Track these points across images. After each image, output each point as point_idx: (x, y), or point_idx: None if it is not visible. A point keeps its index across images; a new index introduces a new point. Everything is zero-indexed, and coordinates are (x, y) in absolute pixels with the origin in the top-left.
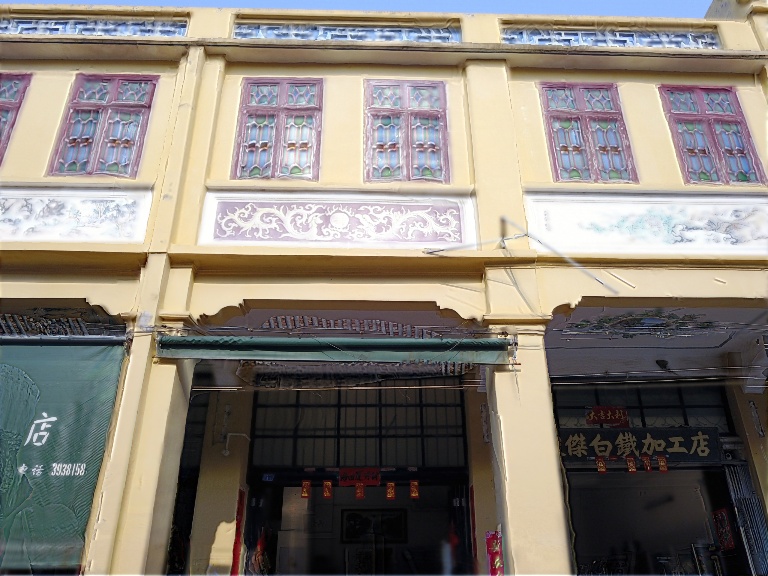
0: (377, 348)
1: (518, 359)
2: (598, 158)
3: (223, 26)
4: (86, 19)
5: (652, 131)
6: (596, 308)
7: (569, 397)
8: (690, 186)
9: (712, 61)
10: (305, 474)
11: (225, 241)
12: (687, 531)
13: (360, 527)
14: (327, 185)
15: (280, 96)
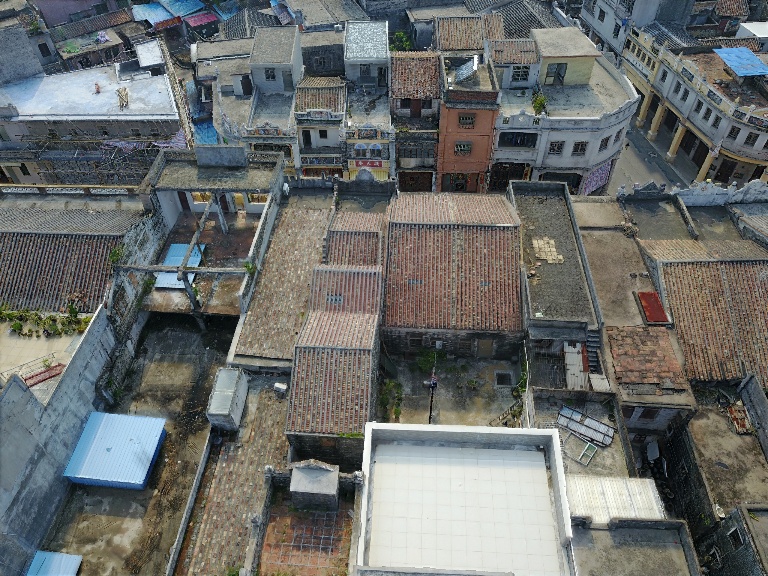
0: None
1: None
2: None
3: None
4: None
5: None
6: None
7: None
8: None
9: None
10: None
11: None
12: None
13: None
14: None
15: None
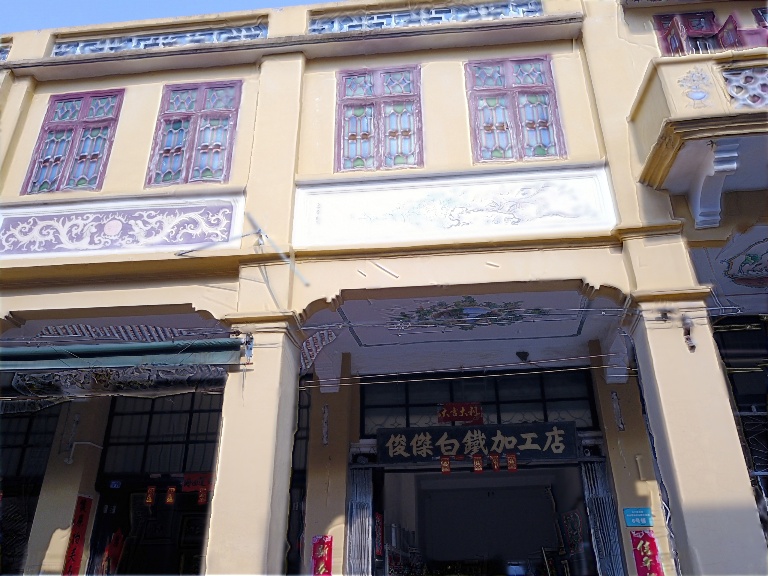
0: (112, 353)
1: (253, 358)
2: (386, 144)
3: (40, 47)
4: None
5: (448, 111)
6: (360, 301)
7: (419, 395)
8: (477, 166)
9: (519, 30)
10: (151, 480)
11: (1, 256)
12: (537, 534)
13: (199, 533)
14: (104, 194)
15: (82, 110)
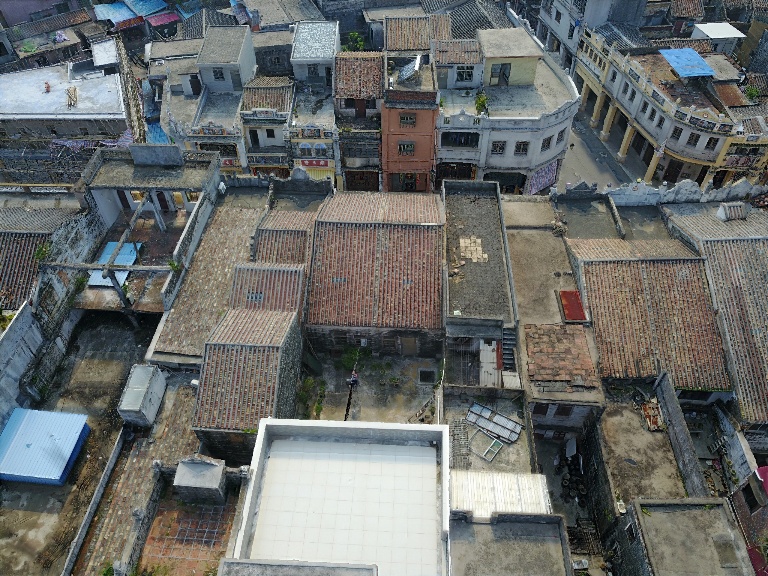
0: None
1: None
2: None
3: None
4: (1, 186)
5: None
6: None
7: None
8: None
9: None
10: None
11: None
12: None
13: None
14: None
15: None
